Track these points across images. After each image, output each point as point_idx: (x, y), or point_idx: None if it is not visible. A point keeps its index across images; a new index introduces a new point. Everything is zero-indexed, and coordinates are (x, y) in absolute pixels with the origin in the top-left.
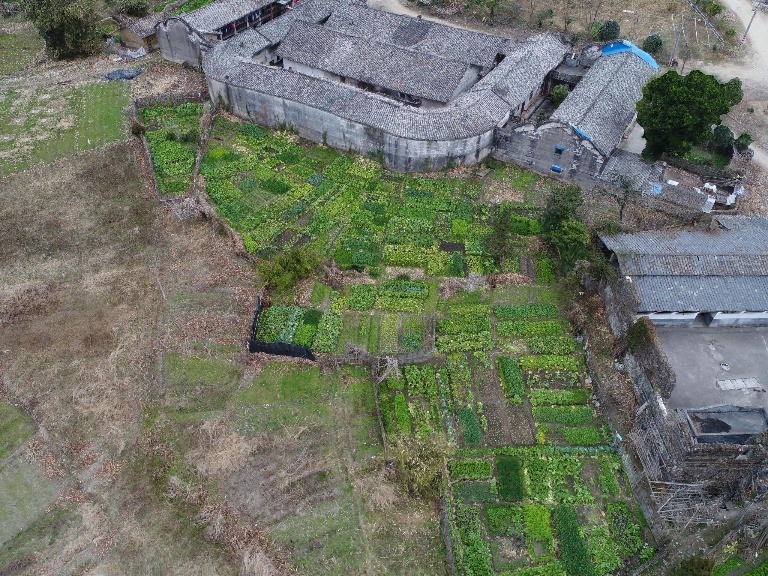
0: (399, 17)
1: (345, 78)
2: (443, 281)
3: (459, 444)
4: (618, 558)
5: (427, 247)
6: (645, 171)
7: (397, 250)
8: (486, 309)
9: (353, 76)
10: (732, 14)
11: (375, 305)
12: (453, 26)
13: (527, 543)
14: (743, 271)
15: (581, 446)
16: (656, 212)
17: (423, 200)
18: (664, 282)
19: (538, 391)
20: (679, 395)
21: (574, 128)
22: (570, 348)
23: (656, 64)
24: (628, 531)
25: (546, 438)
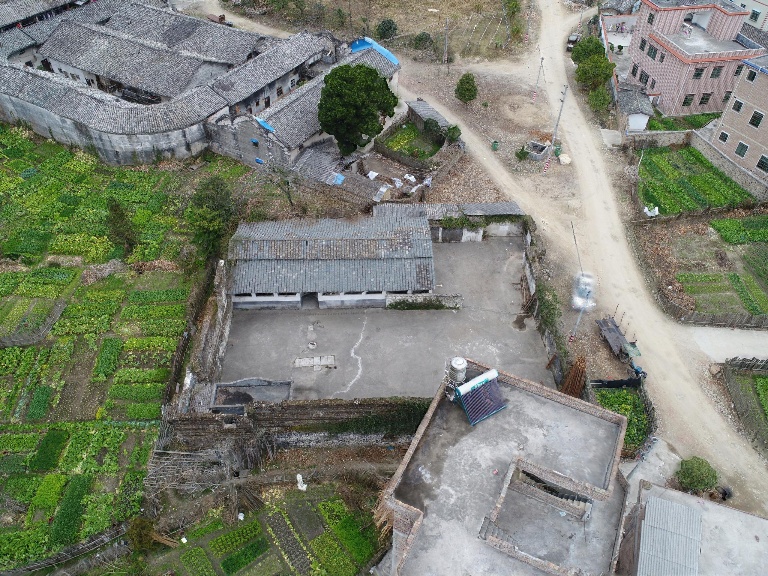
0: (173, 16)
1: (99, 76)
2: (88, 268)
3: (22, 420)
4: (107, 523)
5: (99, 236)
6: (334, 162)
7: (67, 239)
8: (120, 294)
9: (101, 73)
10: (534, 12)
11: (15, 291)
12: (256, 25)
13: (29, 510)
14: (346, 255)
15: (137, 421)
16: (342, 202)
17: (121, 192)
18: (267, 266)
19: (125, 370)
20: (251, 372)
21: (257, 121)
22: (178, 330)
23: (396, 60)
24: (131, 498)
25: (108, 414)
